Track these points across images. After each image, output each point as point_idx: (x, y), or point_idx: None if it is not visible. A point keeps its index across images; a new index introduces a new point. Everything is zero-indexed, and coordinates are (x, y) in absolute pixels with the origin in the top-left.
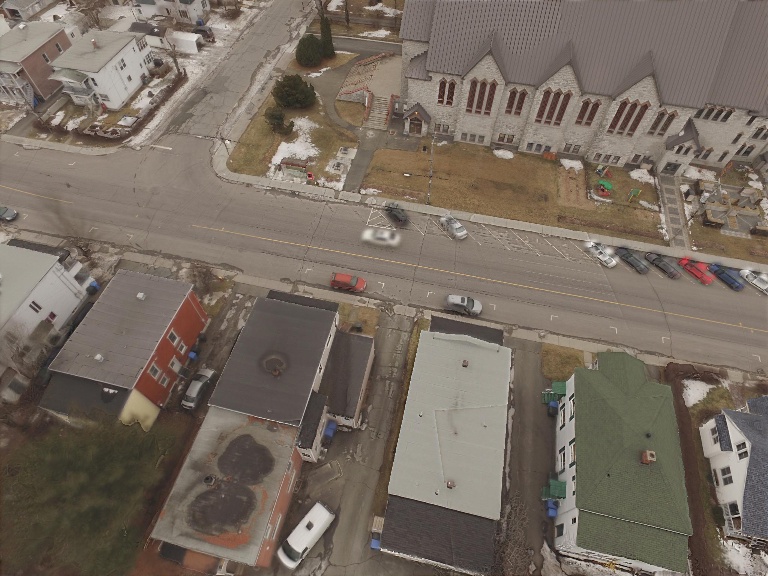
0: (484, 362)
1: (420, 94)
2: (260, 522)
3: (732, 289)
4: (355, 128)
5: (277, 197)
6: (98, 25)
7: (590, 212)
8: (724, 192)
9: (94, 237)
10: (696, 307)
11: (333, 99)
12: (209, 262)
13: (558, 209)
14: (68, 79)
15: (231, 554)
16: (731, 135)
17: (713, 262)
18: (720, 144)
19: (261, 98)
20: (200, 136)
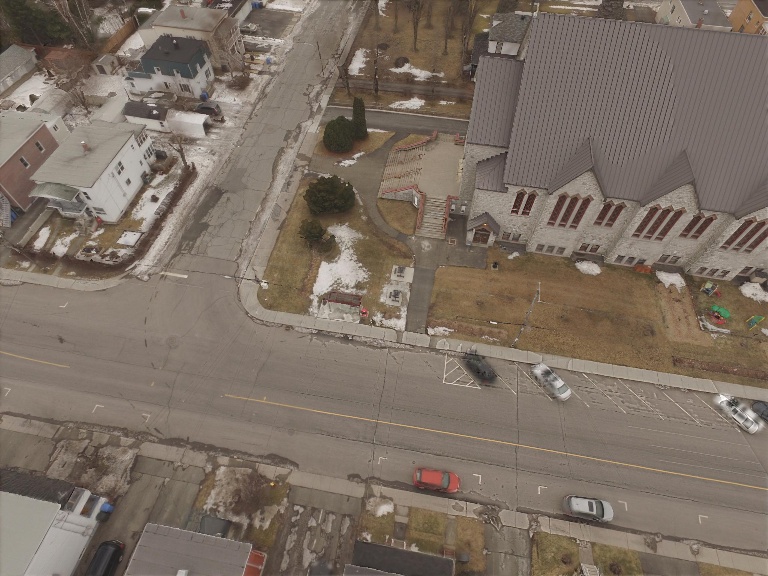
0: None
1: (490, 204)
2: None
3: None
4: (407, 237)
5: (326, 345)
6: (84, 105)
7: (708, 349)
8: None
9: (99, 421)
10: None
11: (374, 197)
12: (253, 453)
13: (670, 346)
14: (54, 197)
15: None
16: None
17: None
18: None
19: (288, 198)
20: (228, 276)
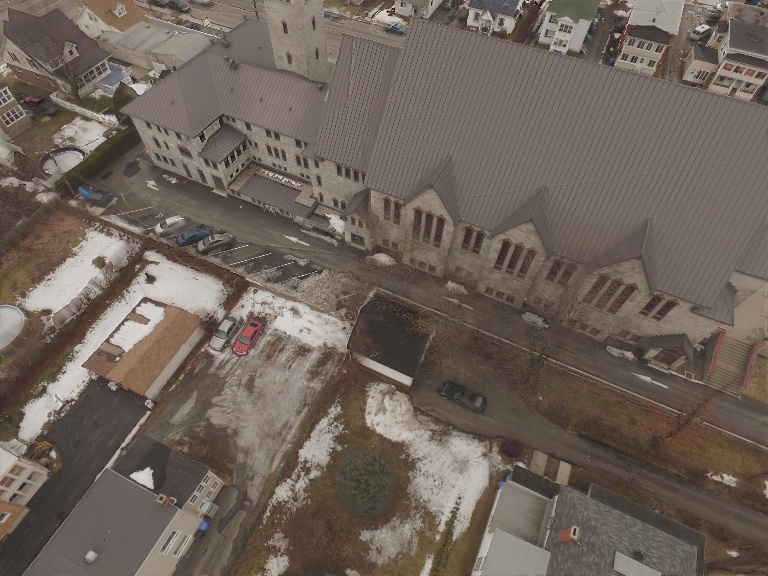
0: (643, 21)
1: None
2: (733, 7)
3: None
4: None
5: None
6: None
7: None
8: None
9: None
10: None
11: None
12: None
13: None
14: None
15: (740, 3)
16: None
17: None
18: None
19: None
20: None
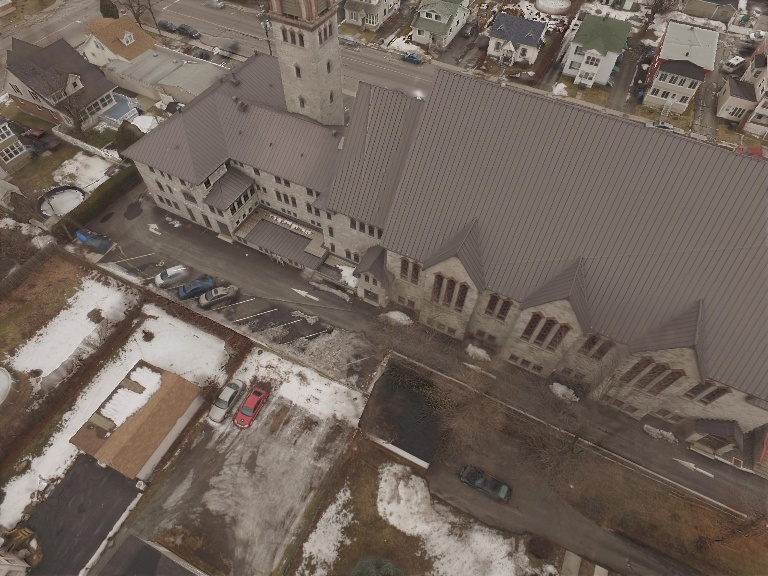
0: (676, 55)
1: None
2: None
3: None
4: None
5: None
6: None
7: None
8: None
9: None
10: None
11: None
12: None
13: None
14: None
15: None
16: None
17: None
18: None
19: None
20: None
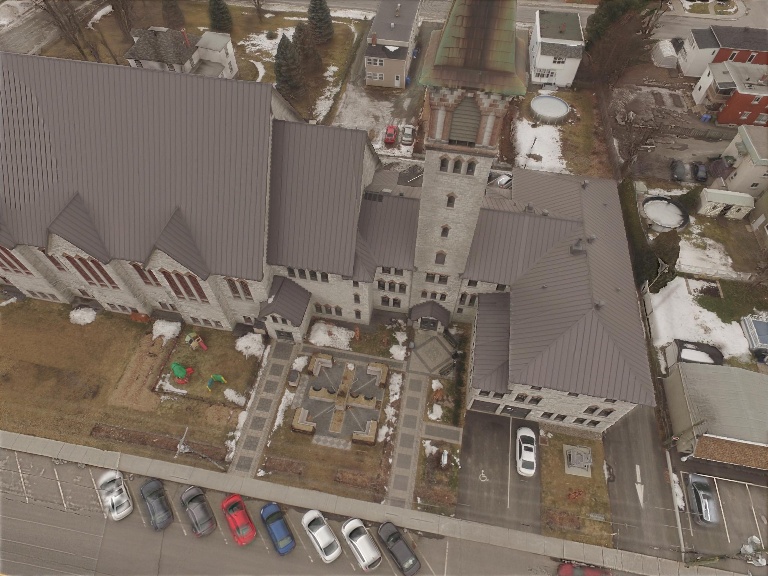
0: None
1: None
2: None
3: (277, 551)
4: None
5: None
6: None
7: (145, 415)
8: (349, 367)
9: None
10: None
11: None
12: None
13: (102, 412)
14: None
15: None
16: (347, 295)
17: (275, 498)
18: (343, 303)
19: None
20: None
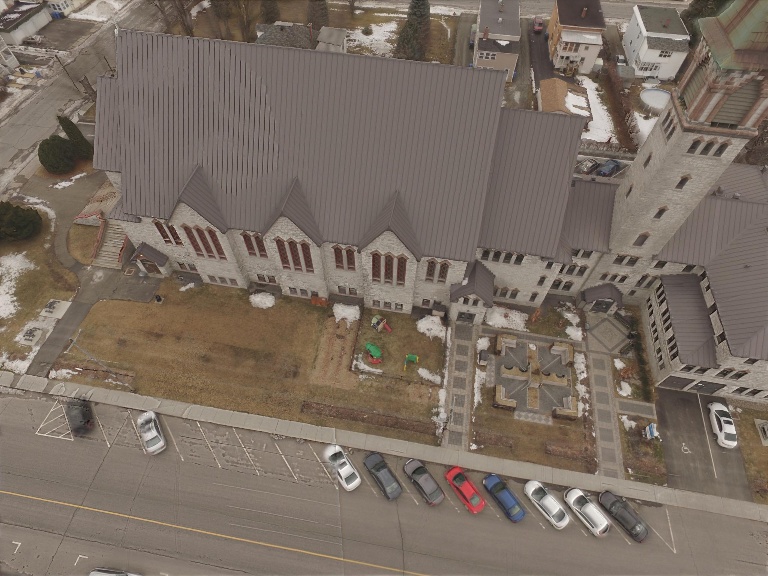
0: None
1: (139, 234)
2: None
3: (508, 519)
4: (81, 267)
5: None
6: None
7: (348, 393)
8: (532, 347)
9: None
10: (450, 558)
11: (70, 222)
12: None
13: (307, 390)
14: None
15: None
16: (533, 277)
17: (493, 470)
18: (524, 285)
19: None
20: None
